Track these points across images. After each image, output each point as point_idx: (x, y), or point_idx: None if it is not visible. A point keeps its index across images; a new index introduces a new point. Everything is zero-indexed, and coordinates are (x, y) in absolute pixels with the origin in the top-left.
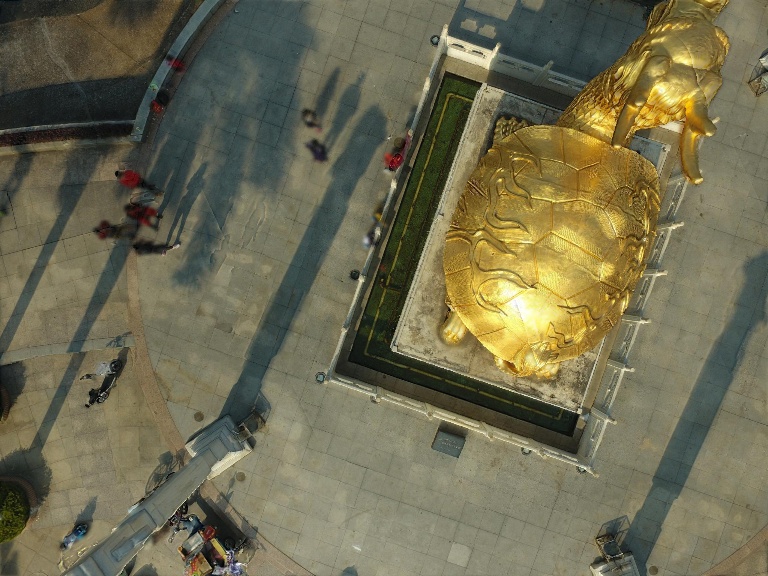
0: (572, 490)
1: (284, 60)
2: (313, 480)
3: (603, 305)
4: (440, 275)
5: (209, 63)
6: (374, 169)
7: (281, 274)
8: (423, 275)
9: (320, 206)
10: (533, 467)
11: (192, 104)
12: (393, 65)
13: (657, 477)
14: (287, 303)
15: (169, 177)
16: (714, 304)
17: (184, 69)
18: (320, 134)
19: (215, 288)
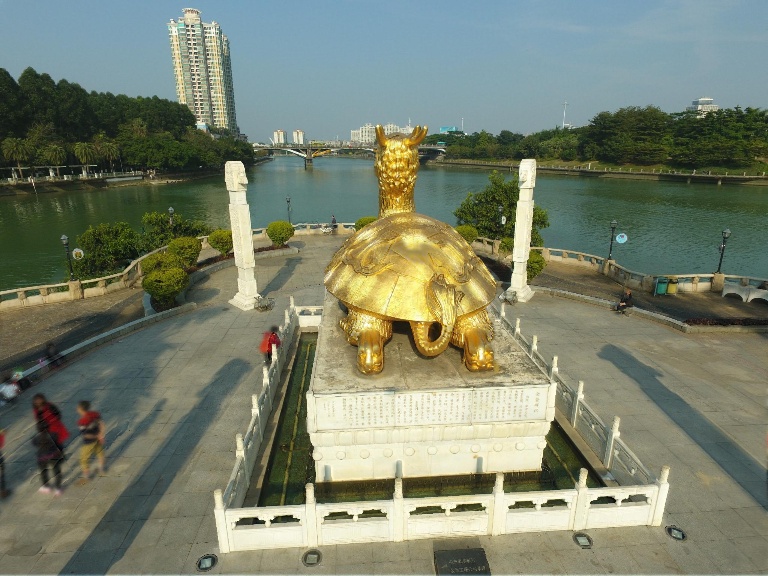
0: (702, 570)
1: (162, 351)
2: None
3: (462, 250)
4: (337, 348)
5: (85, 364)
6: (254, 377)
7: (143, 467)
8: (320, 351)
9: (198, 408)
10: (616, 560)
11: (57, 384)
12: (259, 337)
13: (767, 505)
14: (149, 491)
15: (2, 430)
16: (608, 372)
17: (56, 371)
18: (196, 373)
19: (28, 505)
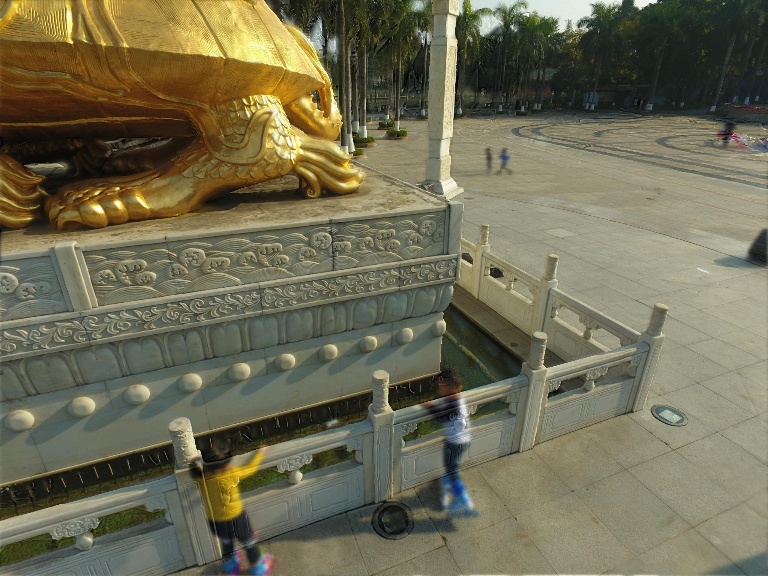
0: None
1: None
2: (763, 330)
3: None
4: (241, 217)
5: None
6: None
7: None
8: None
9: None
10: None
11: None
12: None
13: None
14: None
15: None
16: None
17: None
18: None
19: None
